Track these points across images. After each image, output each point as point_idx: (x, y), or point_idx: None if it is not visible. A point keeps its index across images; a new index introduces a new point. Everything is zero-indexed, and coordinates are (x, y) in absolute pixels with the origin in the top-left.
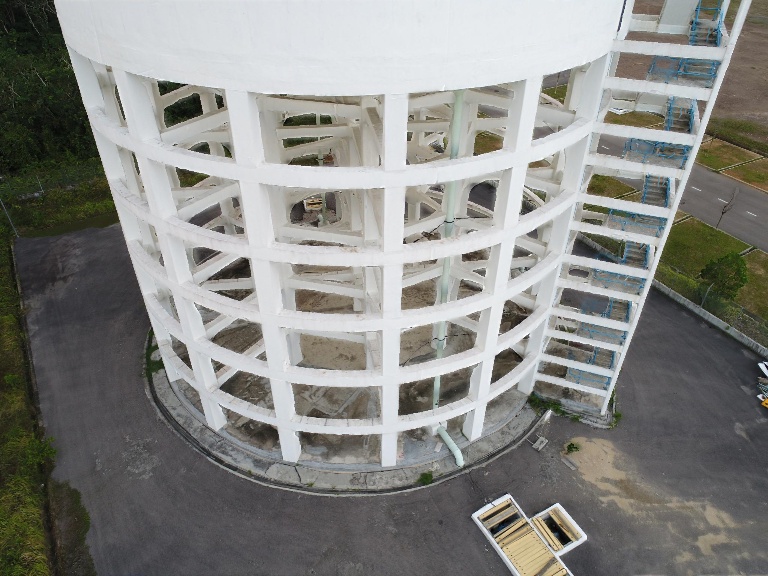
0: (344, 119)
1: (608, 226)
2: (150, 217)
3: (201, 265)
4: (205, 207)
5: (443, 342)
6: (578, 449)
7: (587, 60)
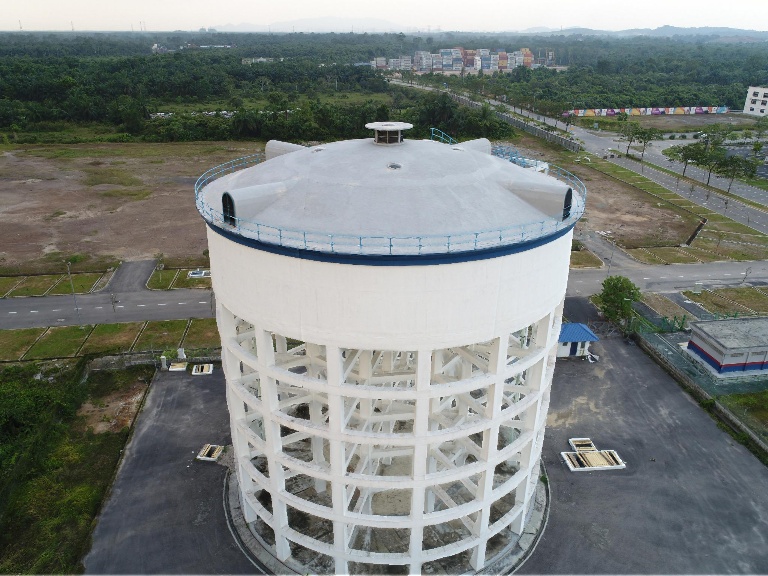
0: None
1: None
2: (490, 423)
3: (474, 447)
4: None
5: None
6: None
7: None
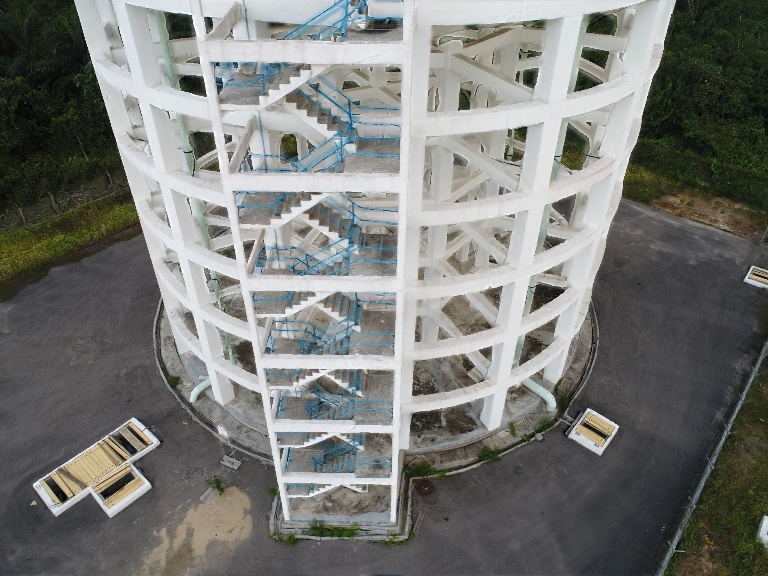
0: (472, 103)
1: (268, 268)
2: None
3: None
4: (195, 73)
5: (214, 282)
6: (229, 500)
7: (180, 9)
